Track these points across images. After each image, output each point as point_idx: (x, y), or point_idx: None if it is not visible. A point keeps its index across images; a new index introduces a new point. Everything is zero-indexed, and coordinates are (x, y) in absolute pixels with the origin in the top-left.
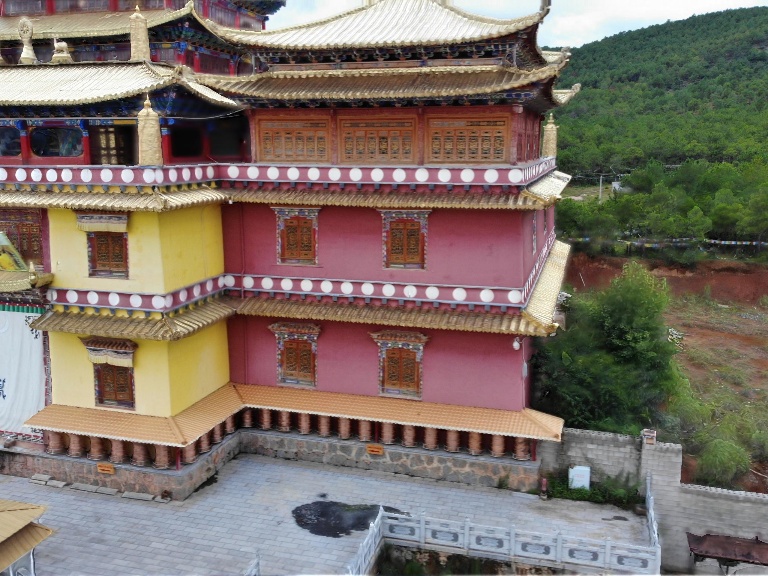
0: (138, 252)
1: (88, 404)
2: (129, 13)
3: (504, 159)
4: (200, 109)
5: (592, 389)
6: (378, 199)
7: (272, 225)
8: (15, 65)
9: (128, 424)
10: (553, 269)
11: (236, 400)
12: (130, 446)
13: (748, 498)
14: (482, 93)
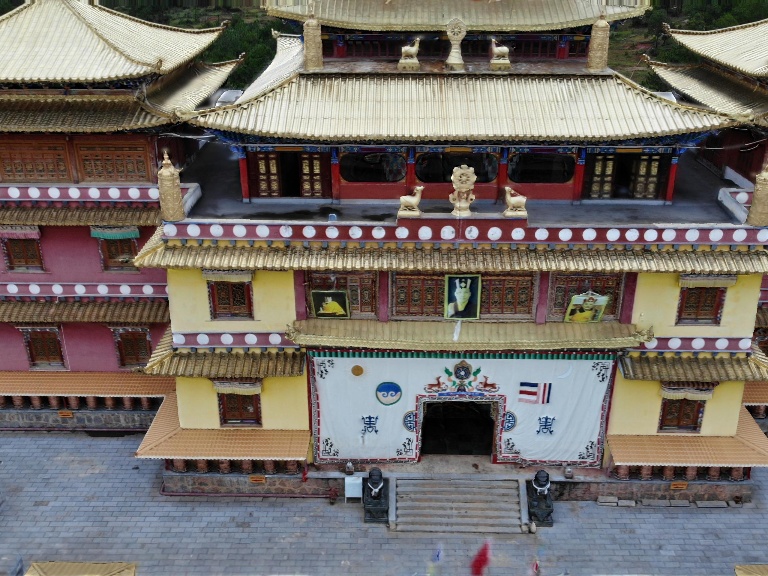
0: (734, 302)
1: (649, 432)
2: None
3: None
4: None
5: None
6: None
7: None
8: (449, 73)
9: (709, 449)
10: None
11: None
12: None
13: None
14: None
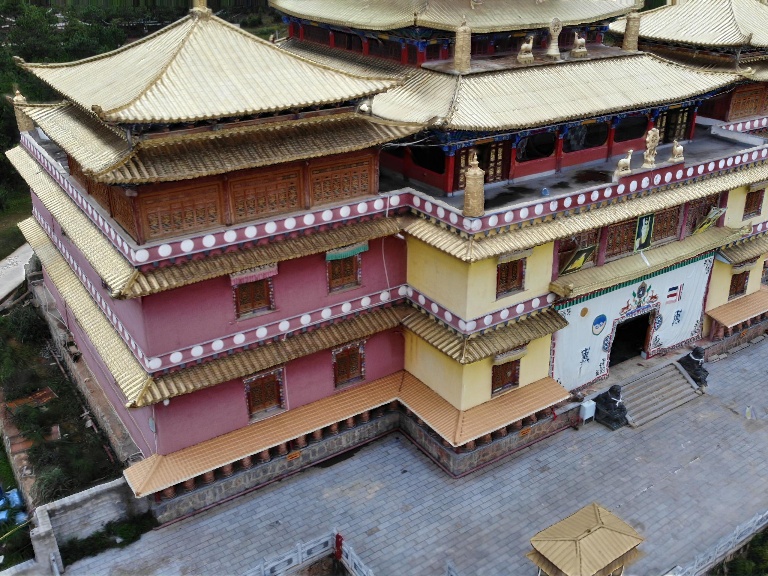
0: (767, 197)
1: (724, 302)
2: None
3: None
4: None
5: None
6: None
7: None
8: (557, 63)
9: (758, 301)
10: None
11: None
12: None
13: None
14: None
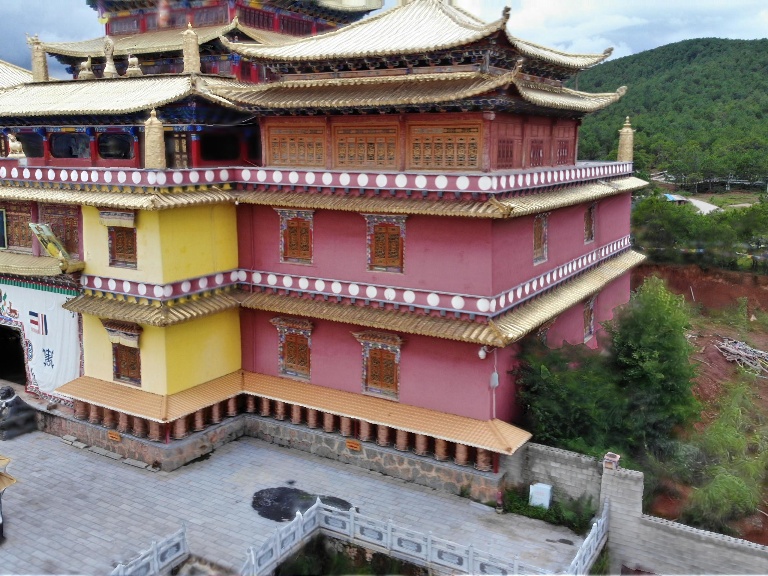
0: (144, 246)
1: (108, 378)
2: (200, 29)
3: (477, 166)
4: (231, 116)
5: (565, 406)
6: (357, 203)
7: (276, 225)
8: (98, 79)
9: (130, 398)
10: (590, 280)
11: (236, 386)
12: (133, 418)
13: (711, 539)
14: (448, 100)
